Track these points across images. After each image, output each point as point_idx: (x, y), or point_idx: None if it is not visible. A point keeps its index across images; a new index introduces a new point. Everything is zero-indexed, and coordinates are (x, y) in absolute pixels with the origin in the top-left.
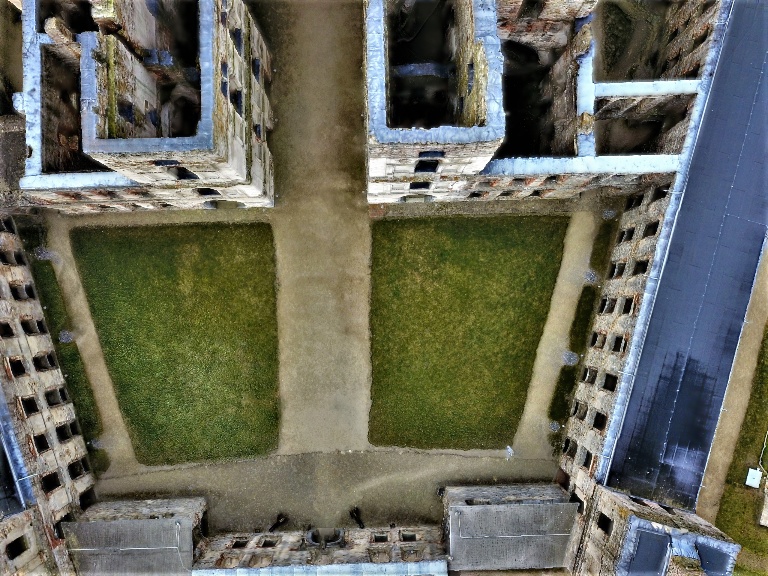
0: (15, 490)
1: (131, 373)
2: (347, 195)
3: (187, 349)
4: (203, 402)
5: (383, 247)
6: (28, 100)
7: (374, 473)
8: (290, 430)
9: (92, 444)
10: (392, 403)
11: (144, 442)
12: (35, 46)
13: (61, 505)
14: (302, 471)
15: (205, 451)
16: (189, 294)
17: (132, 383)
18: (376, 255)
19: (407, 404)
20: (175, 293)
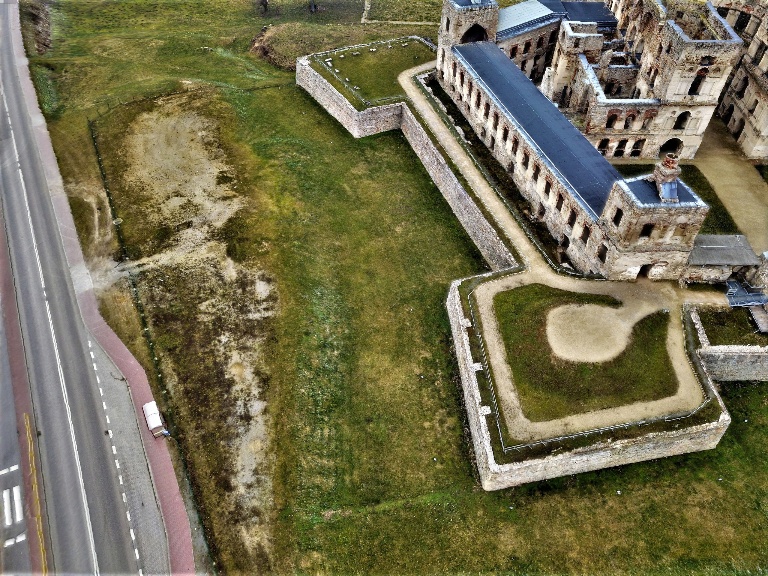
0: None
1: None
2: (734, 156)
3: None
4: None
5: (767, 174)
6: (593, 80)
7: None
8: (756, 246)
9: None
10: None
11: None
12: (590, 67)
13: None
14: None
15: None
16: None
17: None
18: (766, 177)
19: None
20: None
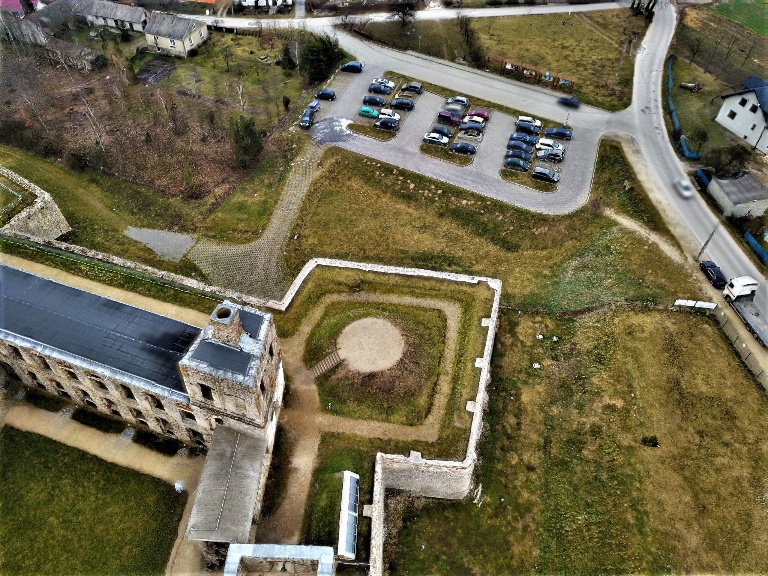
0: None
1: None
2: None
3: None
4: None
5: None
6: None
7: None
8: None
9: None
10: None
11: None
12: None
13: None
14: None
15: None
16: None
17: None
18: None
19: None
20: None
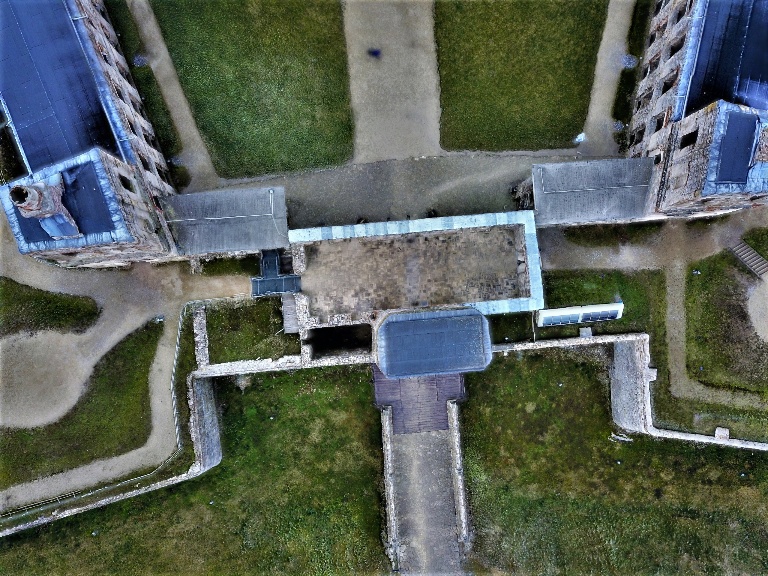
0: (116, 148)
1: (206, 93)
2: None
3: (260, 68)
4: (278, 118)
5: None
6: None
7: (448, 177)
8: (364, 140)
9: (172, 162)
10: (461, 110)
11: (223, 158)
12: None
13: (155, 185)
14: (378, 178)
15: (283, 164)
16: (258, 16)
17: (208, 103)
18: None
19: (476, 110)
20: (245, 16)
